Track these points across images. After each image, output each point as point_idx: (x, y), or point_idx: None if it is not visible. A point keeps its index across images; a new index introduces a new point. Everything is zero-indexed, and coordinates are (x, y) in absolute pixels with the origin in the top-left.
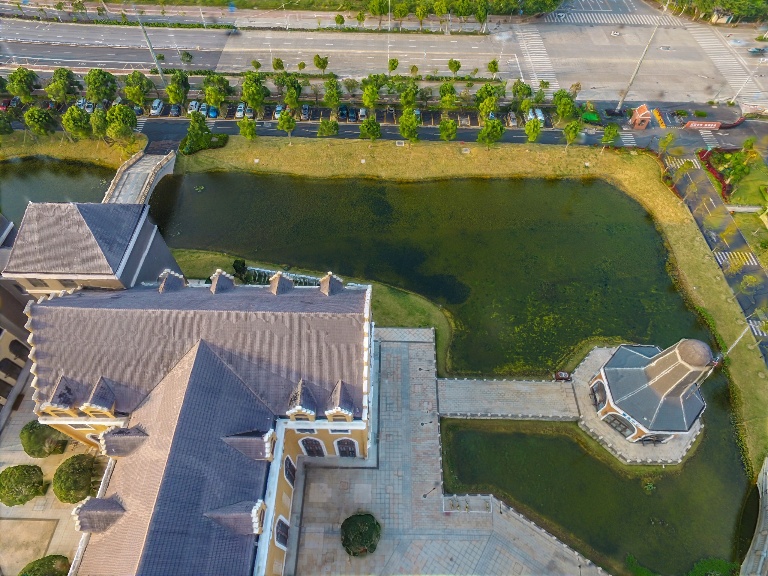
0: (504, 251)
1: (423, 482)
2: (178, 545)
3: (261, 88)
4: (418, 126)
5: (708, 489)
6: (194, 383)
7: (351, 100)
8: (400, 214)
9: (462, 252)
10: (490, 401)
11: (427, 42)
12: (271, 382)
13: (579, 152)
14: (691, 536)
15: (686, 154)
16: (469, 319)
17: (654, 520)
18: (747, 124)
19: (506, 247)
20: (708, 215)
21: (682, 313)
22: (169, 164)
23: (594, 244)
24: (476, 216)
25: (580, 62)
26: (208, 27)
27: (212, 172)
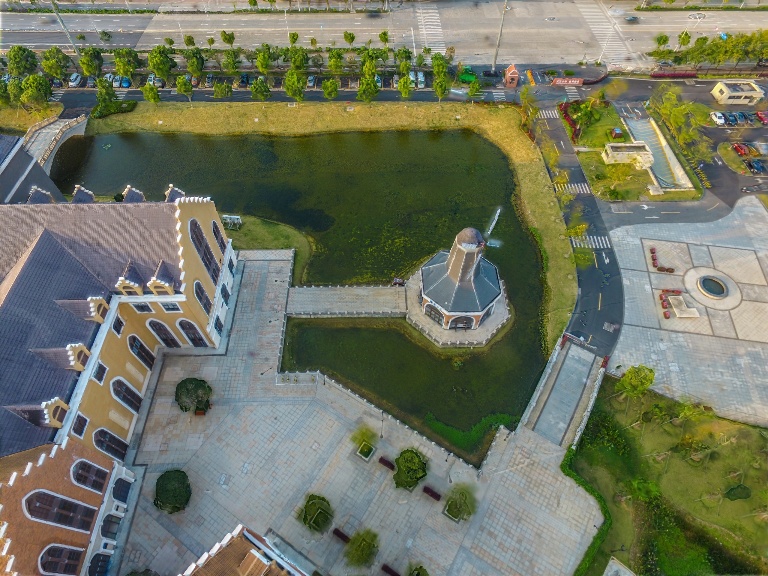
0: (371, 189)
1: (262, 364)
2: (1, 366)
3: (166, 59)
4: (311, 90)
5: (508, 364)
6: (33, 259)
7: (254, 70)
8: (284, 162)
9: (333, 191)
10: (332, 303)
11: (333, 20)
12: (105, 263)
13: (452, 107)
14: (485, 399)
15: (549, 106)
16: (329, 243)
17: (456, 388)
18: (609, 80)
19: (373, 186)
20: (556, 155)
21: (517, 233)
22: (79, 126)
23: (452, 181)
24: (351, 162)
25: (470, 33)
26: (133, 12)
27: (120, 133)
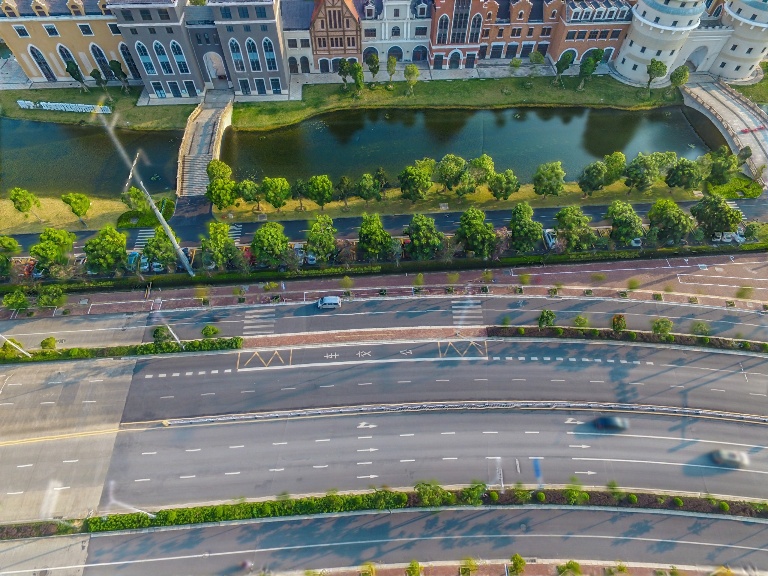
0: None
1: None
2: None
3: None
4: None
5: None
6: None
7: None
8: None
9: None
10: None
11: None
12: None
13: None
14: None
15: None
16: None
17: None
18: None
19: None
20: None
21: None
22: None
23: None
24: None
25: None
26: None
27: None
